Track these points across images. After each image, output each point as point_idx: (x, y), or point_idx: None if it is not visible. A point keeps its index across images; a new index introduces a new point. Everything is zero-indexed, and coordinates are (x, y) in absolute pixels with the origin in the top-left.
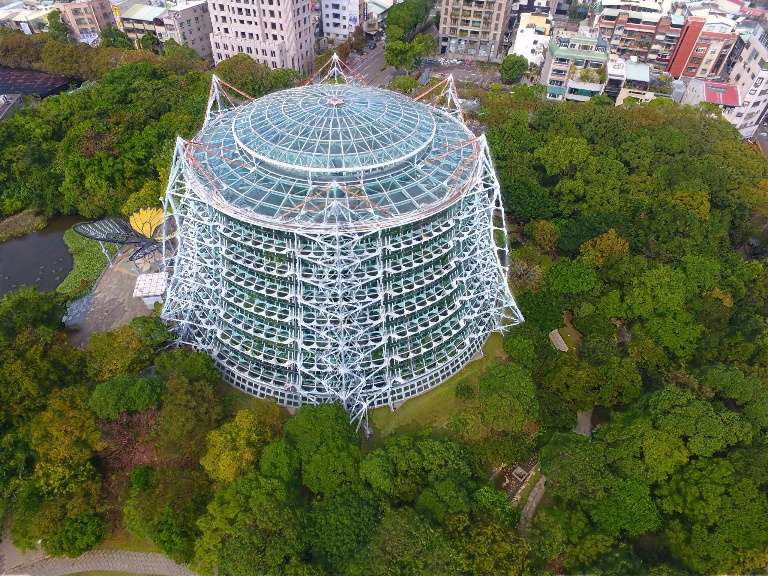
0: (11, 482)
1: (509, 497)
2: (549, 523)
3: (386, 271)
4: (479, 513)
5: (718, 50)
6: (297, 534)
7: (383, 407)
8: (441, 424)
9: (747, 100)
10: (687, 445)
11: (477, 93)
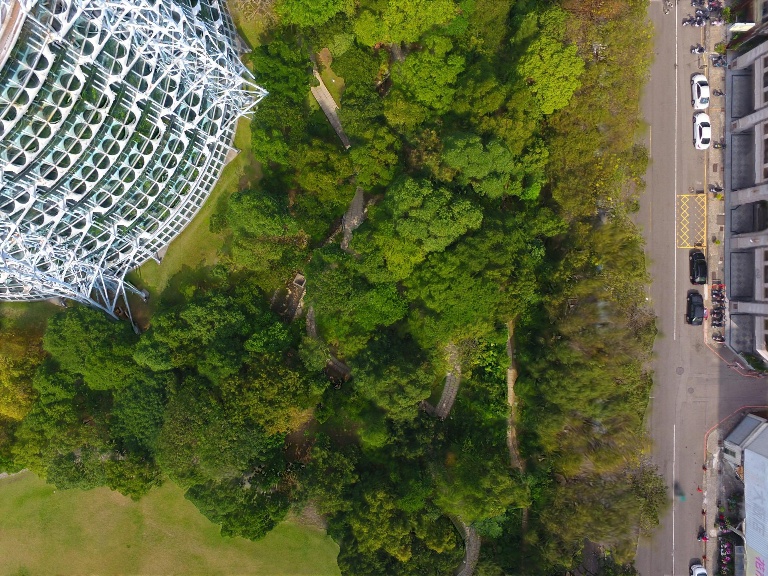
0: None
1: (294, 306)
2: (314, 345)
3: (8, 170)
4: (251, 362)
5: None
6: (103, 439)
7: (148, 262)
8: (211, 262)
9: None
10: (421, 248)
11: None
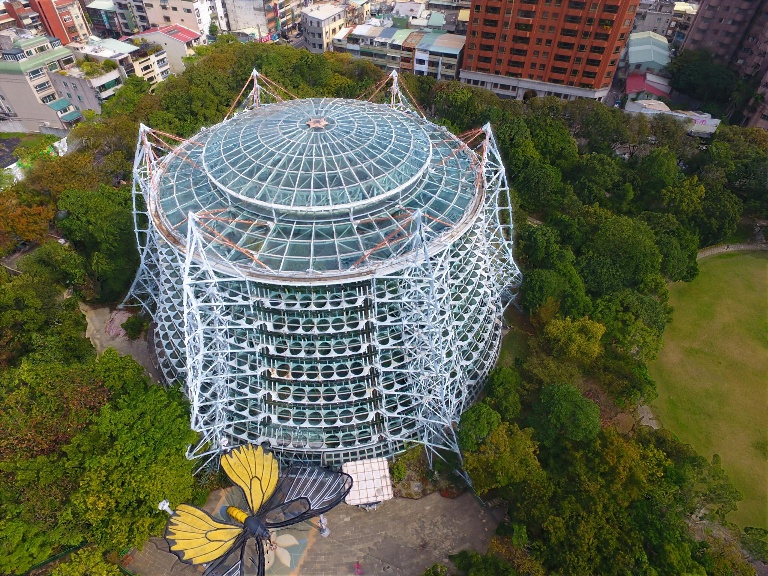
0: (689, 475)
1: None
2: None
3: None
4: None
5: (79, 13)
6: None
7: None
8: None
9: (201, 29)
10: None
11: (81, 132)
